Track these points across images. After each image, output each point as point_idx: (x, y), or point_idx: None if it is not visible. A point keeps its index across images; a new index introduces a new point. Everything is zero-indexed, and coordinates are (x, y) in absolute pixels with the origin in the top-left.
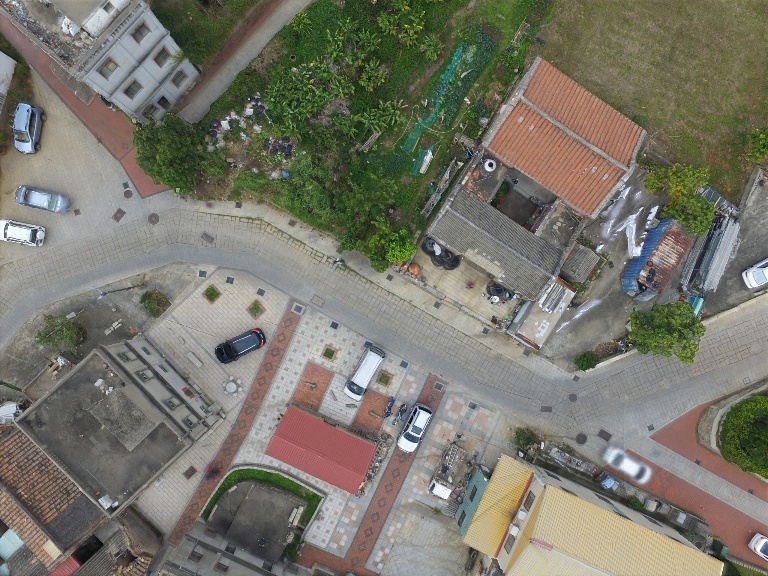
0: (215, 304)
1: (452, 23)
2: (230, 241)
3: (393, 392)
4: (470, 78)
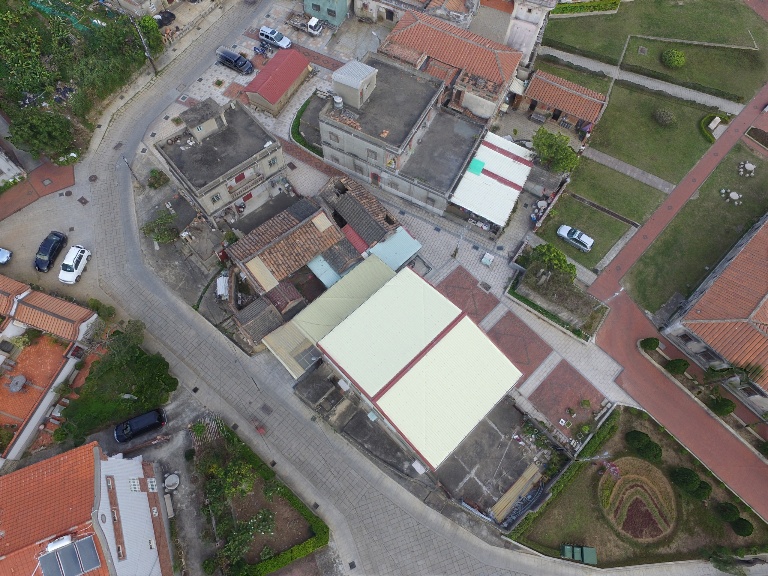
0: None
1: (14, 7)
2: (124, 134)
3: (252, 53)
4: (53, 0)
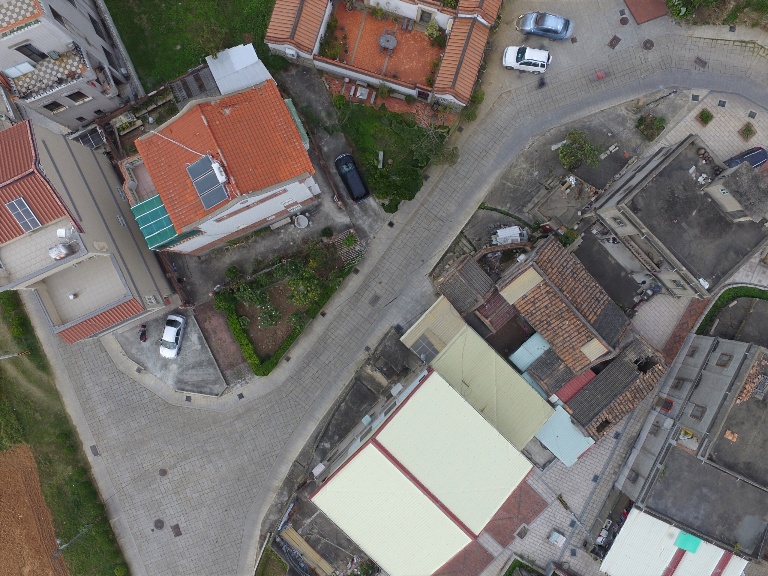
0: (707, 127)
1: None
2: (722, 65)
3: None
4: None
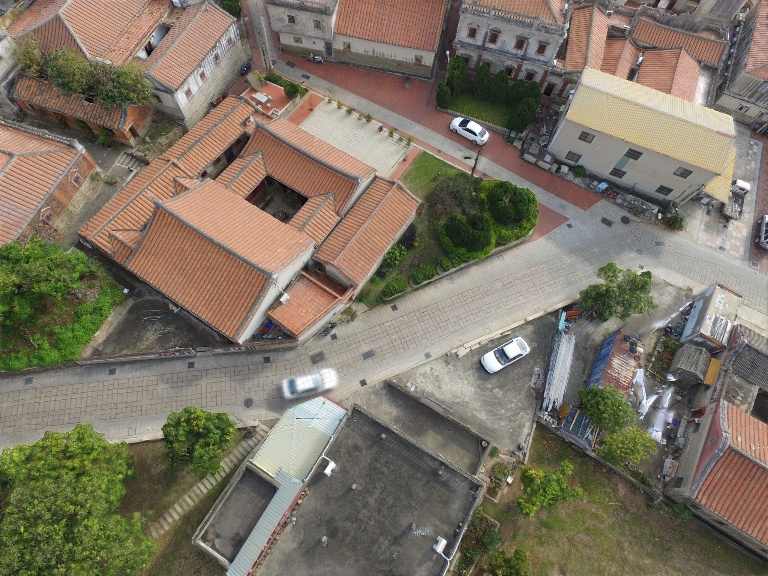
0: None
1: None
2: None
3: None
4: None
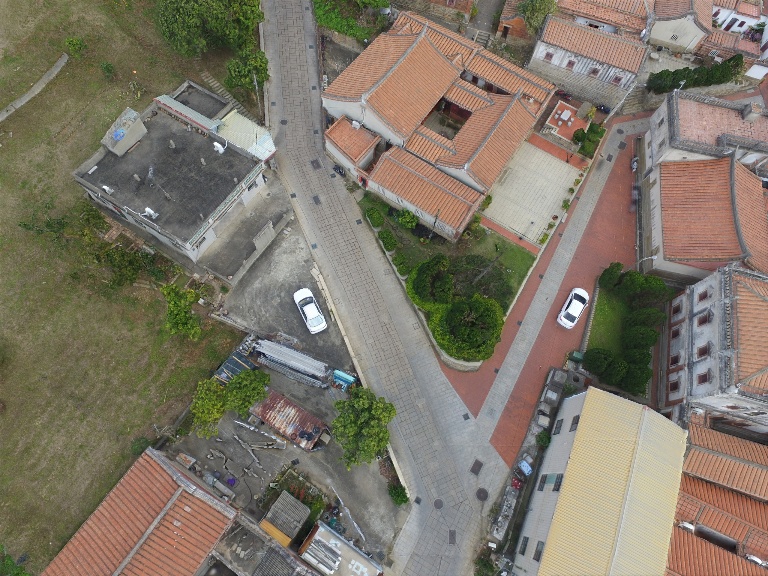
0: None
1: None
2: None
3: None
4: None
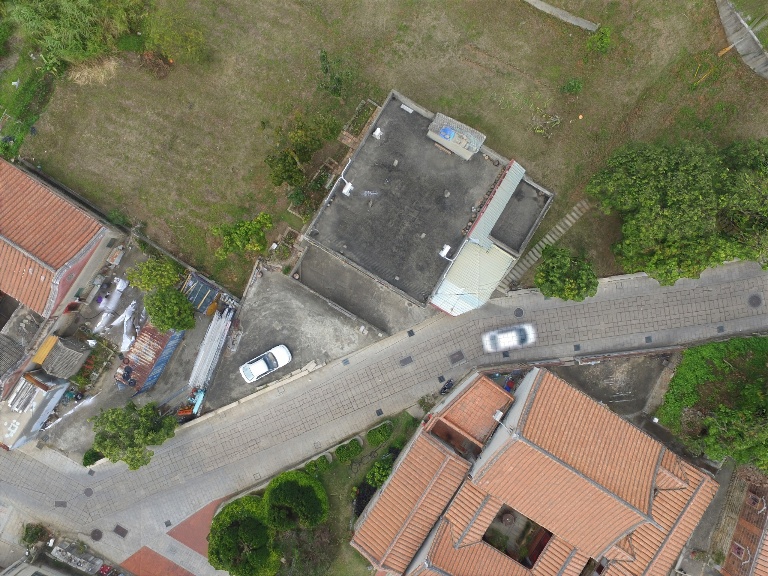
0: None
1: None
2: None
3: None
4: None
